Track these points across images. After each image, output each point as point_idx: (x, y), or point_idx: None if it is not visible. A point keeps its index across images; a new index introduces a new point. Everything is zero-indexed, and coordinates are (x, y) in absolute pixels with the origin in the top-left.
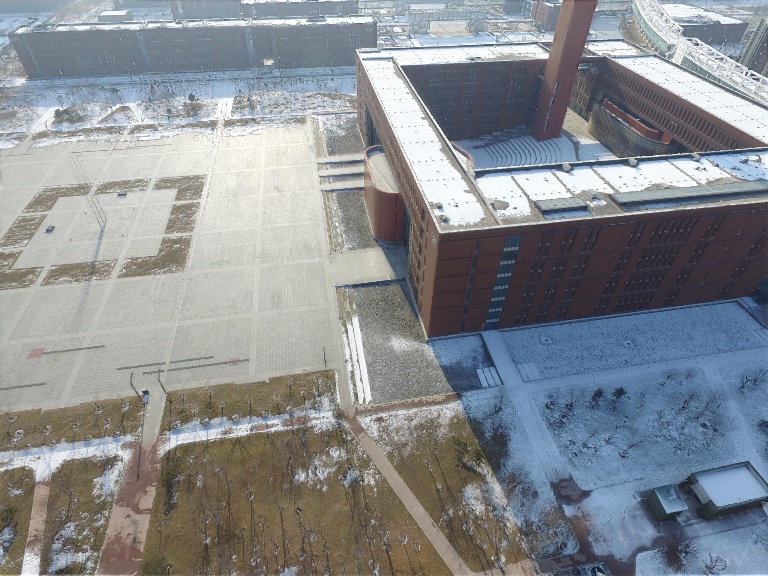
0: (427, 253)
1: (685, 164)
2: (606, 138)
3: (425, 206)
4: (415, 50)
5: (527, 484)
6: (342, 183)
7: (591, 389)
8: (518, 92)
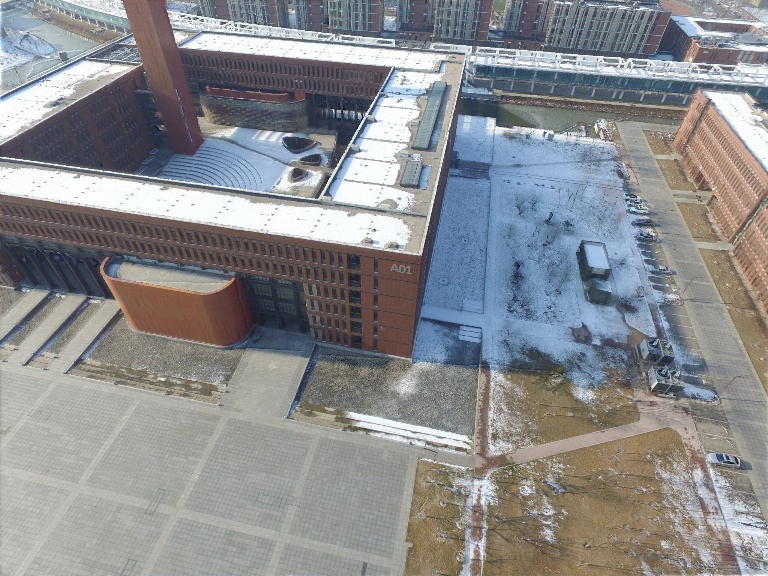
0: (384, 290)
1: (388, 102)
2: (242, 120)
3: (362, 251)
4: None
5: (575, 355)
6: (74, 343)
7: (502, 280)
8: (129, 118)
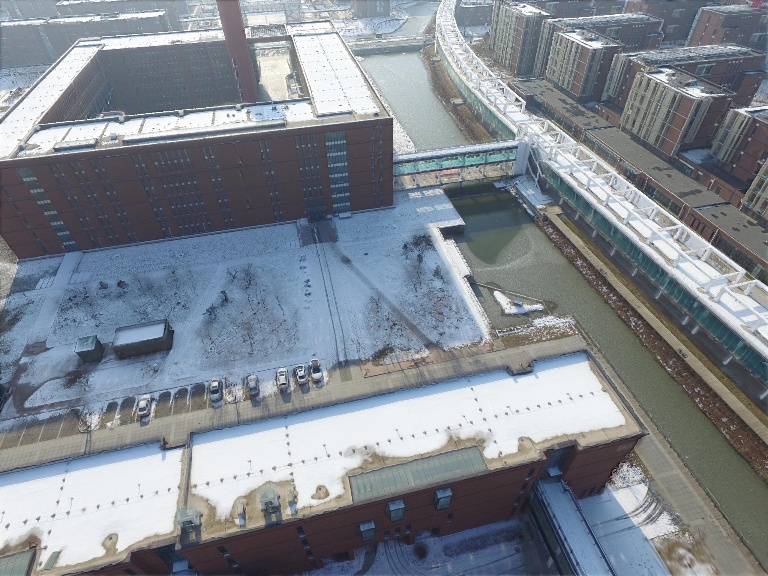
0: None
1: (224, 113)
2: None
3: None
4: (134, 37)
5: (7, 346)
6: None
7: (116, 286)
8: (222, 69)
